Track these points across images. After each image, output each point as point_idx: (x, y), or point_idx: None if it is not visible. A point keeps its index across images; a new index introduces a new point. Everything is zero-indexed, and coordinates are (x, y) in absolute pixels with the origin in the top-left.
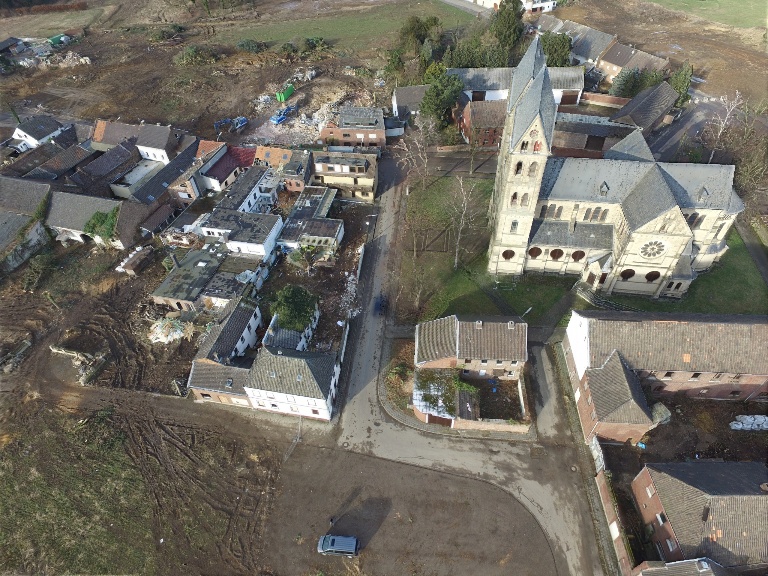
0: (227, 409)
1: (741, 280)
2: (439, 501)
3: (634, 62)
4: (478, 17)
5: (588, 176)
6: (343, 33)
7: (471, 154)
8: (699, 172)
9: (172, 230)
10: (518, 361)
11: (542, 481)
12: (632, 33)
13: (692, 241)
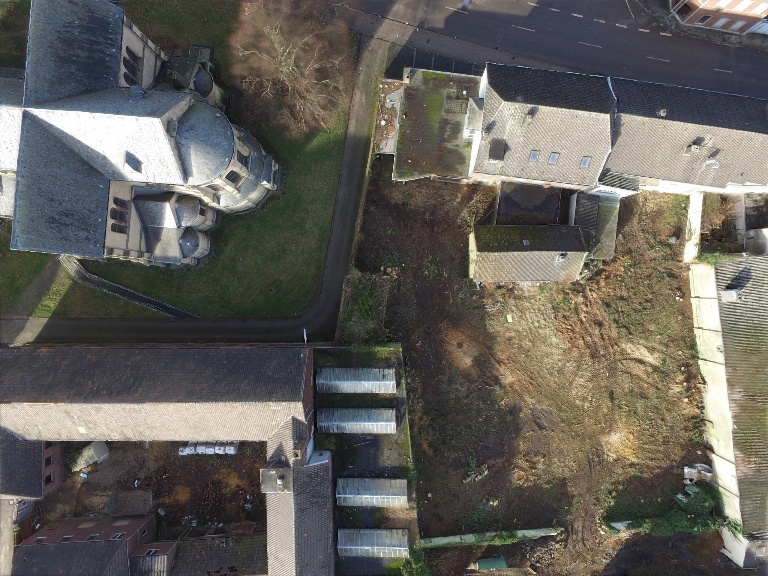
0: None
1: (297, 222)
2: None
3: None
4: None
5: None
6: None
7: None
8: (106, 127)
9: None
10: None
11: None
12: None
13: None
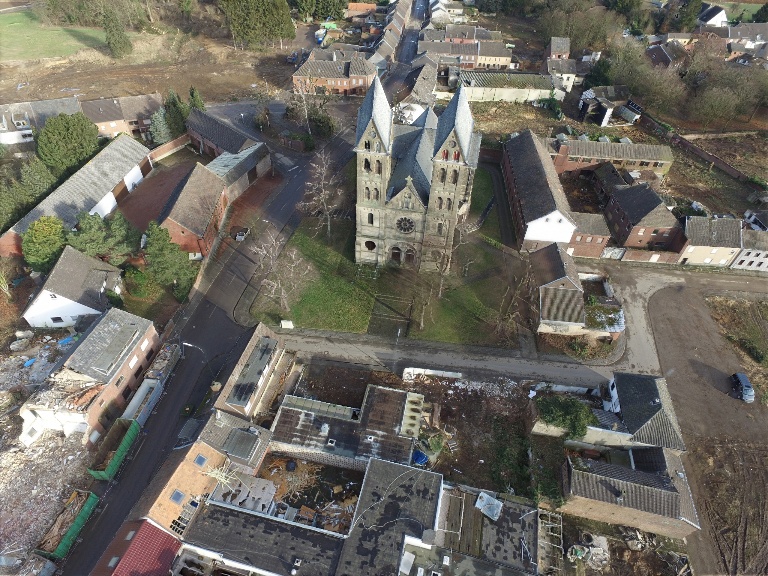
0: None
1: None
2: (674, 333)
3: (128, 109)
4: None
5: (426, 161)
6: None
7: None
8: (431, 120)
9: None
10: None
11: (635, 282)
12: (2, 98)
13: None
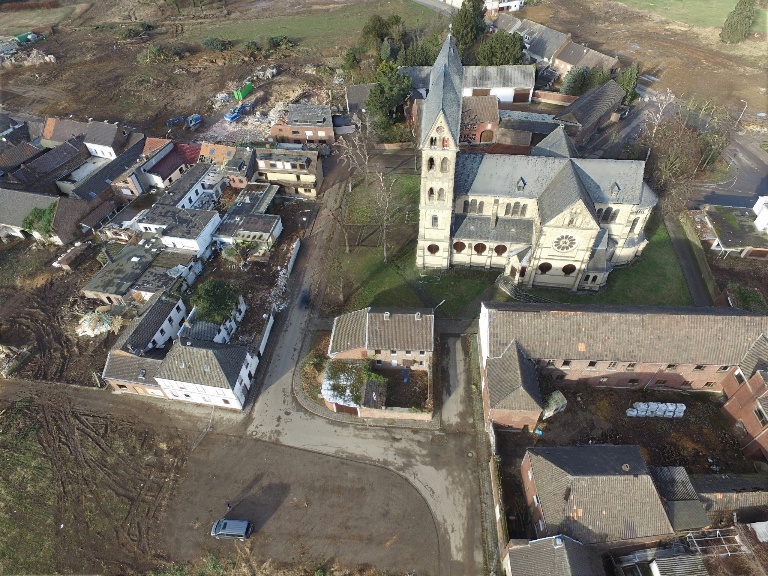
0: (143, 400)
1: (660, 273)
2: (336, 486)
3: (586, 61)
4: (439, 16)
5: (506, 172)
6: (309, 32)
7: (414, 151)
8: (611, 168)
9: (110, 226)
10: (425, 351)
11: (438, 467)
12: (594, 32)
13: (609, 235)
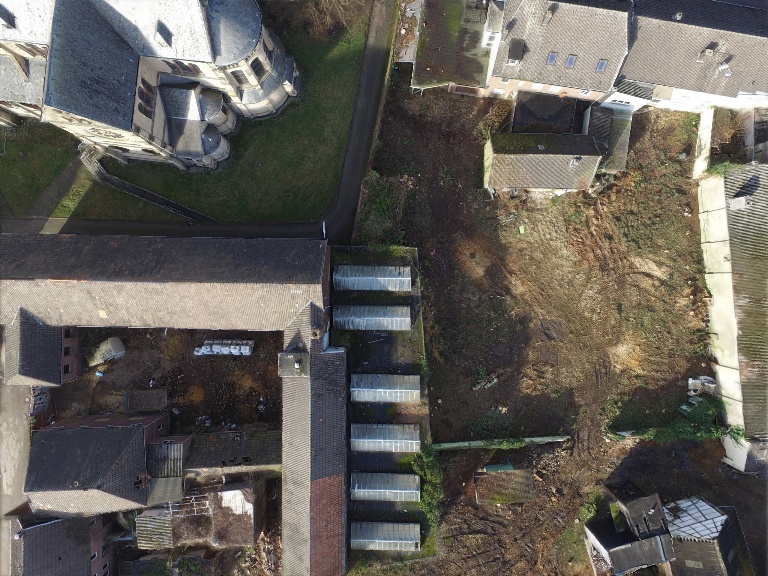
0: None
1: (315, 129)
2: None
3: None
4: None
5: None
6: None
7: None
8: None
9: None
10: None
11: None
12: None
13: None
